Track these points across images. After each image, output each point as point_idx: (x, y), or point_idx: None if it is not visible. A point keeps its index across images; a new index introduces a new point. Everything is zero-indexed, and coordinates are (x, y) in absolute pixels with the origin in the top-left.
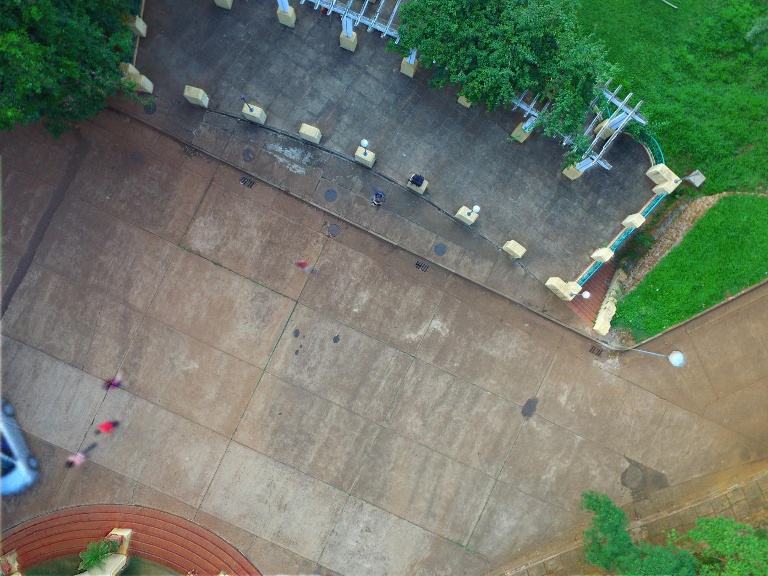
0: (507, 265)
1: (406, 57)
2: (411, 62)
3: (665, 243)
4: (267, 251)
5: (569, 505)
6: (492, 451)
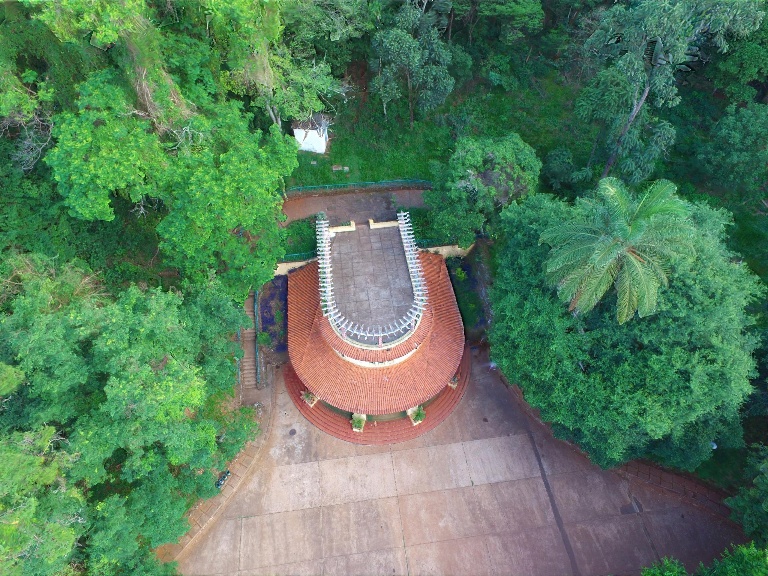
0: None
1: None
2: None
3: None
4: None
5: None
6: None
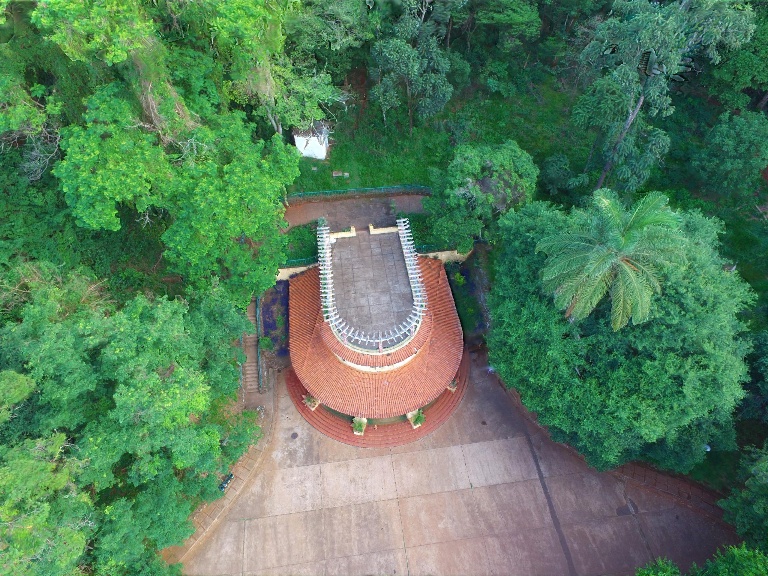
0: None
1: None
2: None
3: None
4: None
5: None
6: None
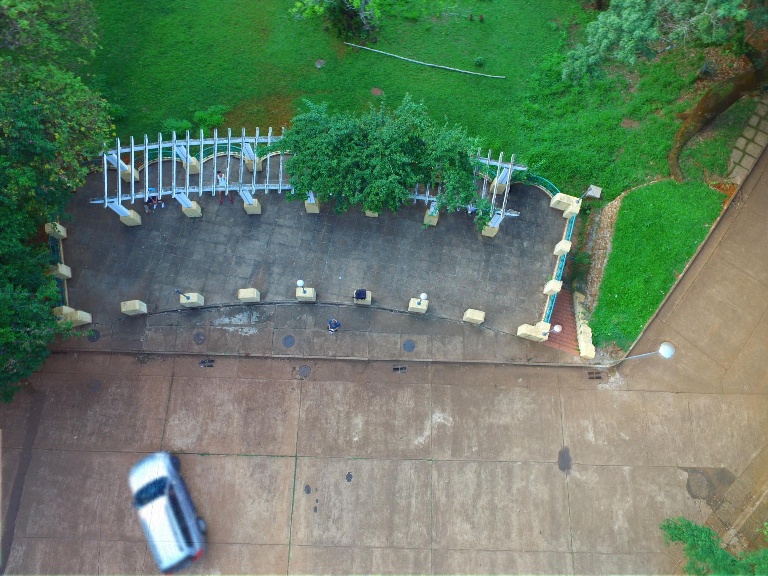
0: (475, 333)
1: (306, 200)
2: (312, 202)
3: (599, 254)
4: (249, 419)
5: (656, 545)
6: (552, 523)
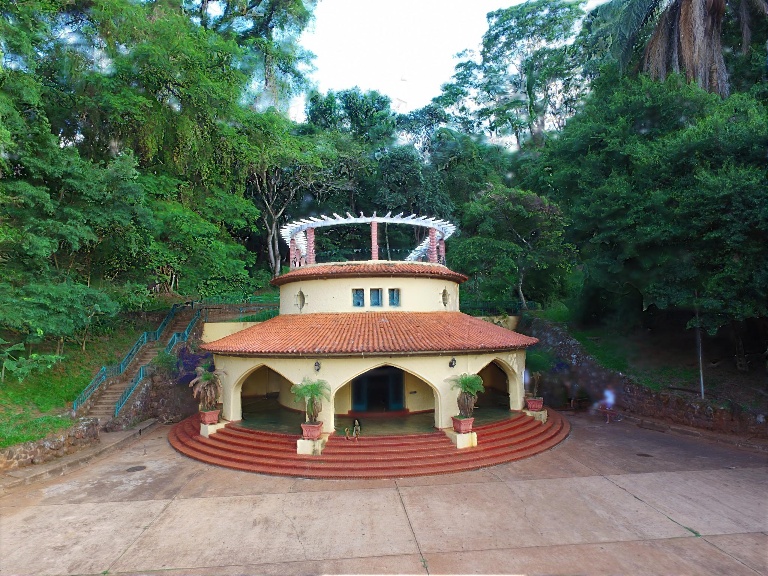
0: None
1: None
2: None
3: None
4: None
5: None
6: None
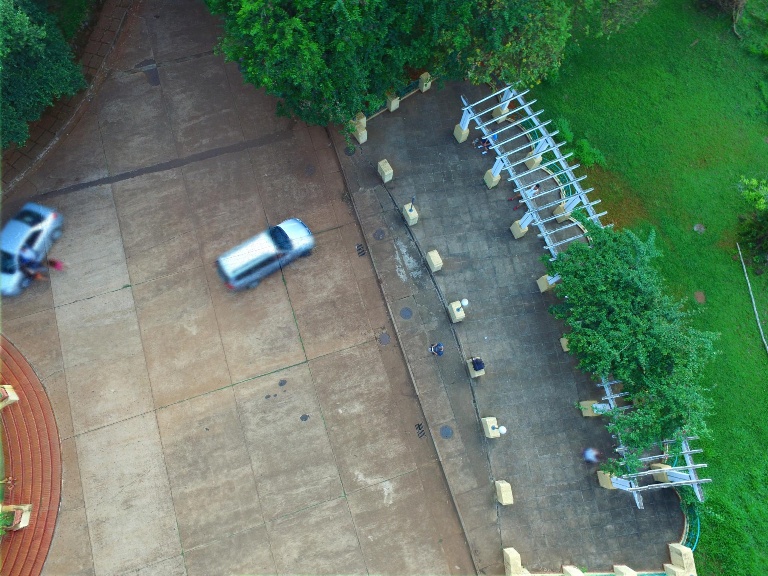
0: (487, 499)
1: (549, 275)
2: (550, 282)
3: None
4: (325, 306)
5: None
6: None
